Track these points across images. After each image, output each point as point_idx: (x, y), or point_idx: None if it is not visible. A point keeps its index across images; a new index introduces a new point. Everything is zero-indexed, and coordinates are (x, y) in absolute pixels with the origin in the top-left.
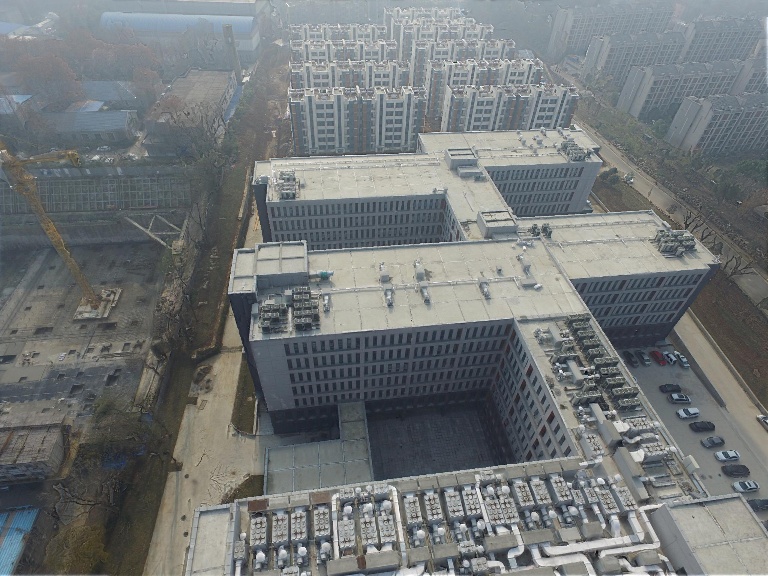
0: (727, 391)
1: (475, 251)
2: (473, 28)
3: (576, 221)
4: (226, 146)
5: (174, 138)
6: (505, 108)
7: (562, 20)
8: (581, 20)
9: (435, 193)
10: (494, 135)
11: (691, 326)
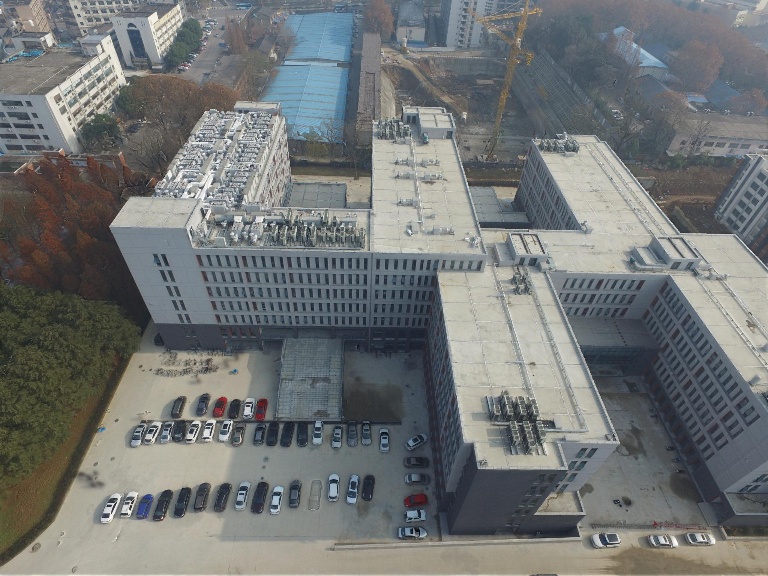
0: (355, 570)
1: (461, 210)
2: None
3: (558, 329)
4: (672, 157)
5: (658, 129)
6: None
7: None
8: None
9: (581, 224)
10: None
11: None
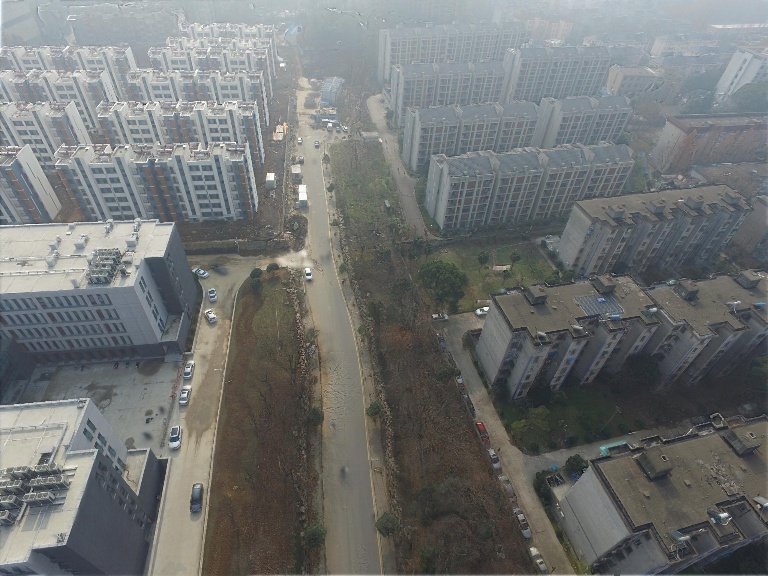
0: None
1: None
2: (241, 53)
3: None
4: None
5: None
6: (139, 176)
7: (383, 42)
8: (402, 43)
9: None
10: (29, 232)
11: (188, 572)
